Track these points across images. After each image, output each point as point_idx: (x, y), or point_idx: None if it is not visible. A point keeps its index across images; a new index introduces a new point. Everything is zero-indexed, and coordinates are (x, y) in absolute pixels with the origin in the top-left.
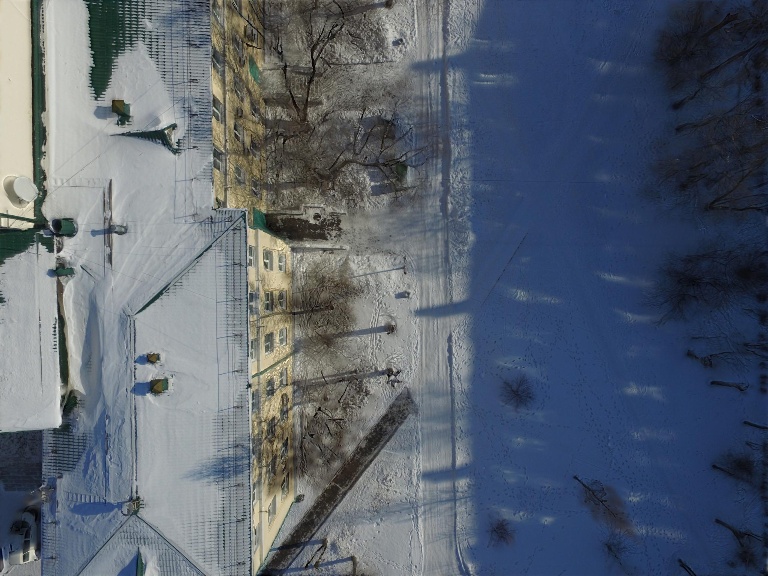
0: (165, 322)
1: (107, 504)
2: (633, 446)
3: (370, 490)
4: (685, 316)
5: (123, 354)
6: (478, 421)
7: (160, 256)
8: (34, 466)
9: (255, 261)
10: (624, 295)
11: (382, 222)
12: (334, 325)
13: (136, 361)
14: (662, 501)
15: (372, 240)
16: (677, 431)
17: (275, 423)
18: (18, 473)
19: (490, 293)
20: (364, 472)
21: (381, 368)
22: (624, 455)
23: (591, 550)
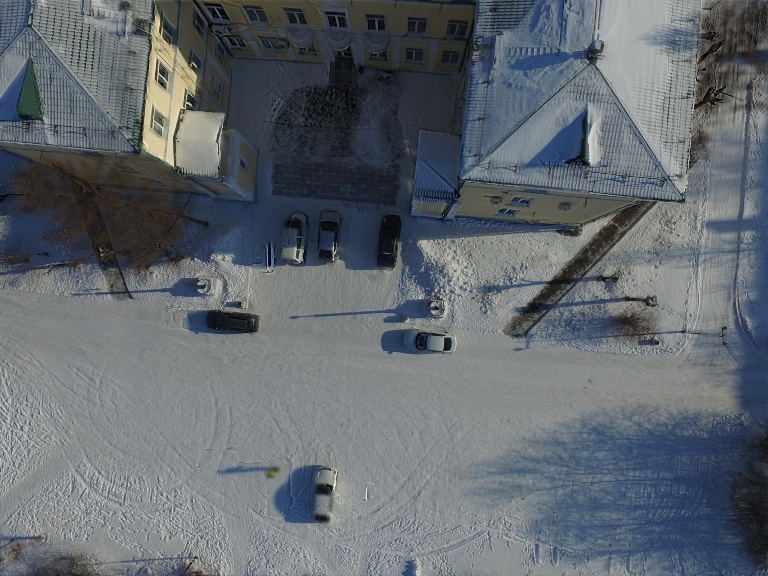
0: None
1: (561, 54)
2: None
3: (652, 231)
4: None
5: None
6: None
7: None
8: (312, 166)
9: None
10: None
11: None
12: None
13: None
14: None
15: None
16: None
17: None
18: (292, 173)
19: None
20: (646, 213)
21: None
22: None
23: None
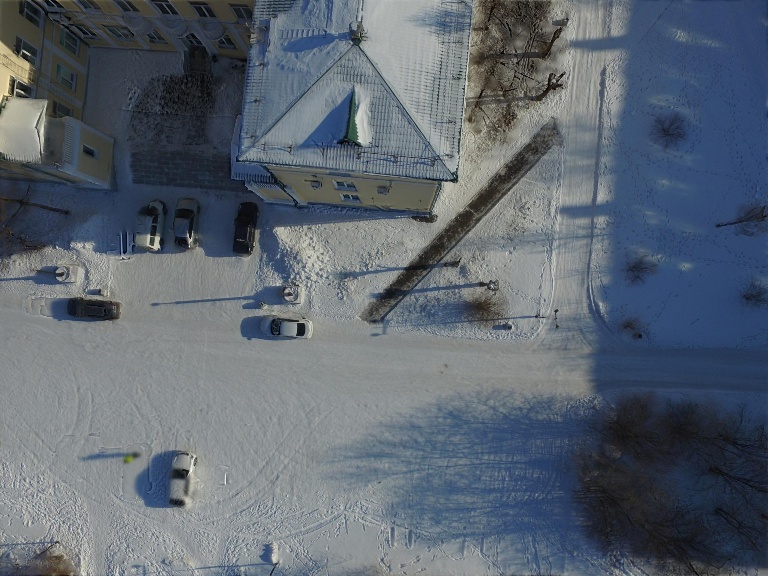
0: None
1: (327, 35)
2: None
3: (506, 217)
4: None
5: None
6: (624, 159)
7: None
8: (168, 154)
9: None
10: None
11: None
12: (487, 46)
13: None
14: None
15: None
16: None
17: None
18: (150, 161)
19: (649, 30)
20: (501, 199)
21: (530, 94)
22: None
23: (727, 301)
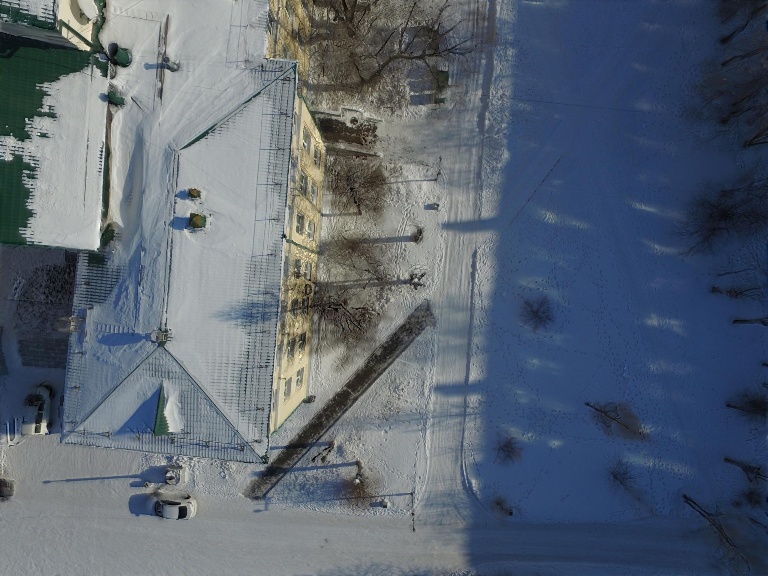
0: (208, 161)
1: (135, 335)
2: (648, 378)
3: (381, 397)
4: (714, 251)
5: (165, 187)
6: (495, 339)
7: (209, 97)
8: (53, 341)
9: (297, 130)
10: (654, 226)
11: (418, 133)
12: (361, 230)
13: (177, 195)
14: (672, 436)
15: (406, 150)
16: (694, 367)
17: (298, 307)
18: (37, 347)
19: (519, 213)
20: (377, 379)
21: (403, 277)
22: (638, 386)
23: (596, 478)
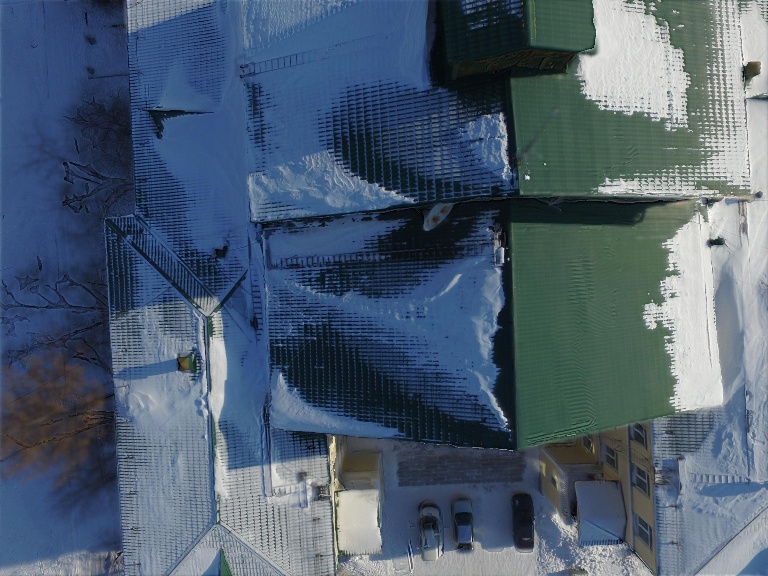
0: None
1: (752, 484)
2: None
3: None
4: None
5: (766, 326)
6: None
7: None
8: (437, 459)
9: None
10: None
11: None
12: None
13: None
14: None
15: None
16: None
17: None
18: (418, 467)
19: None
20: None
21: None
22: None
23: None
